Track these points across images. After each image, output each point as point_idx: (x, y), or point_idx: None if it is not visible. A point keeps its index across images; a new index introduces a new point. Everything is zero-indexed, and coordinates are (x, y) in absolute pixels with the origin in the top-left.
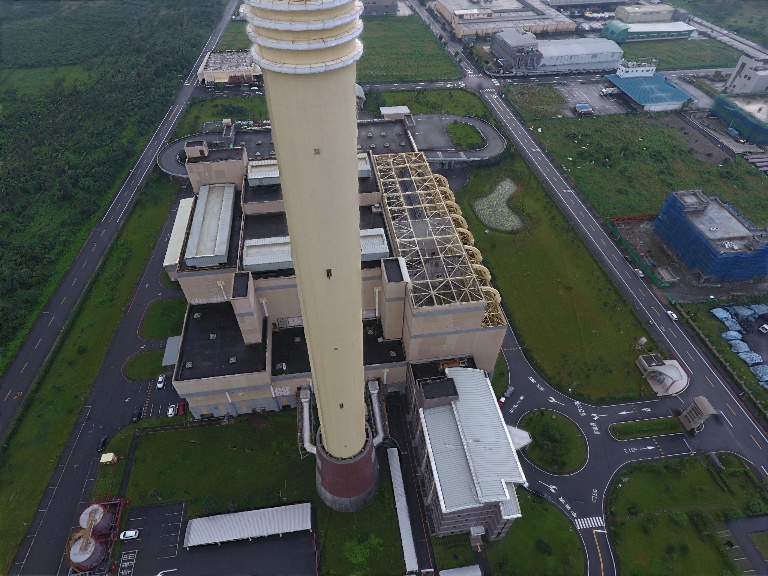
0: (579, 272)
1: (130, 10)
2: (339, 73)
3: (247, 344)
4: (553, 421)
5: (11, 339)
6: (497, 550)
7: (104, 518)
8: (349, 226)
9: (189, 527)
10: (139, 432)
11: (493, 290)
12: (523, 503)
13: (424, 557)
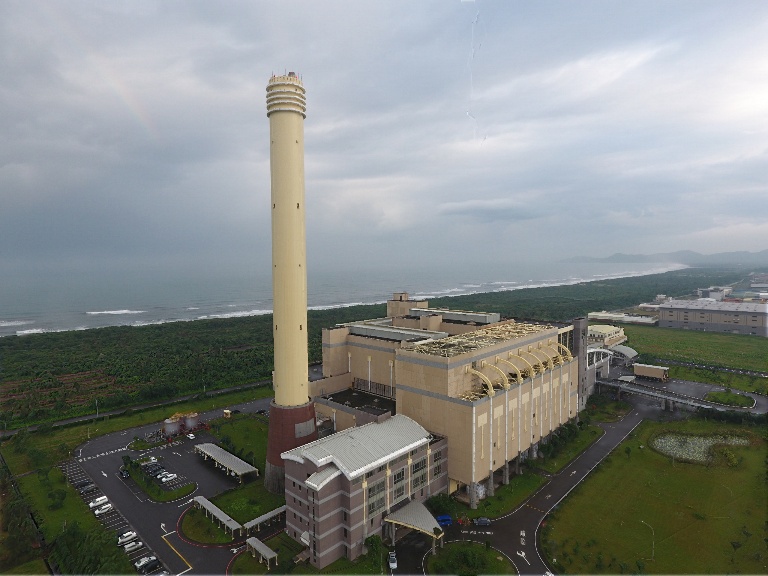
0: (741, 517)
1: (513, 309)
2: (281, 114)
3: (323, 376)
4: (493, 559)
5: (267, 376)
6: (306, 571)
7: (193, 420)
8: (284, 182)
9: (207, 443)
10: (251, 416)
11: (484, 377)
12: (371, 571)
13: (263, 536)
